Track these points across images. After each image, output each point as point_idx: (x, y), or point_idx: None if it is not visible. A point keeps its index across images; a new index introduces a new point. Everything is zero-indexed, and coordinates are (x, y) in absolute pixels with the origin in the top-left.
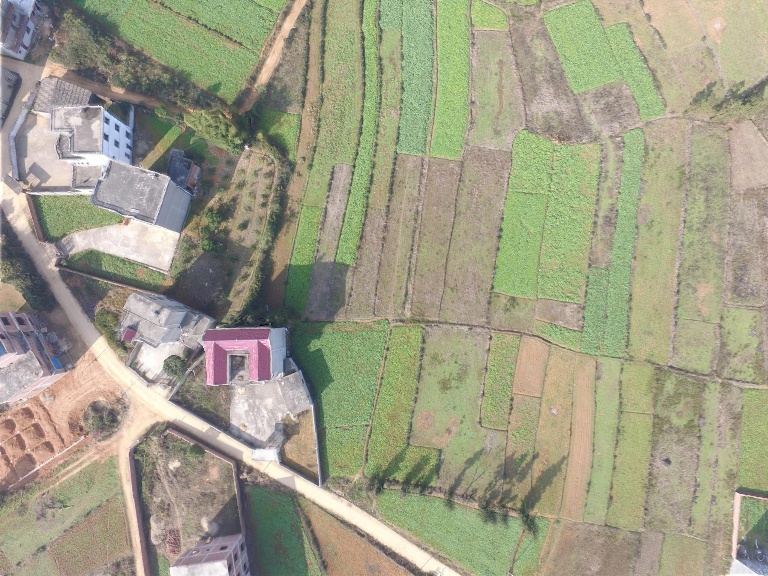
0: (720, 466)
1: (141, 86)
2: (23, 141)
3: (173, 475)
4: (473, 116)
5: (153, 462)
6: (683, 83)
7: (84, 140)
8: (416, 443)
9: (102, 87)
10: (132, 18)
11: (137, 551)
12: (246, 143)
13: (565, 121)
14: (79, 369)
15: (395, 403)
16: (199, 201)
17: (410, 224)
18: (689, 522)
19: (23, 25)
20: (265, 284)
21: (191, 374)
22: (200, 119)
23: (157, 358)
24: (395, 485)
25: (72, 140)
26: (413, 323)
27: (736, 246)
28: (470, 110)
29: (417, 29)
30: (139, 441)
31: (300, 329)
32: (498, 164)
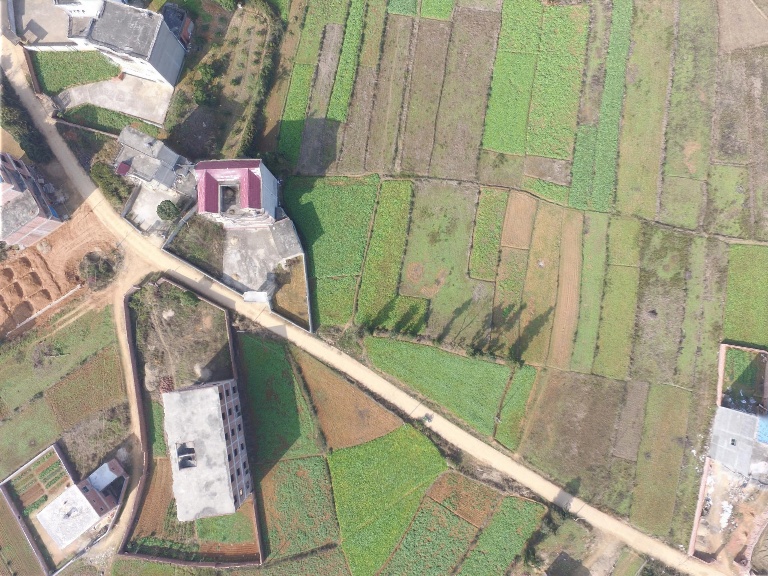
0: (706, 318)
1: None
2: None
3: (167, 324)
4: None
5: (147, 312)
6: None
7: None
8: (405, 293)
9: None
10: None
11: (132, 398)
12: (239, 1)
13: None
14: (75, 220)
15: (385, 254)
16: (193, 57)
17: (400, 82)
18: (674, 371)
19: None
20: (257, 139)
21: (185, 226)
22: None
23: (151, 210)
24: (384, 333)
25: None
26: (403, 178)
27: (723, 105)
28: None
29: None
30: (133, 286)
31: (292, 183)
32: (488, 24)
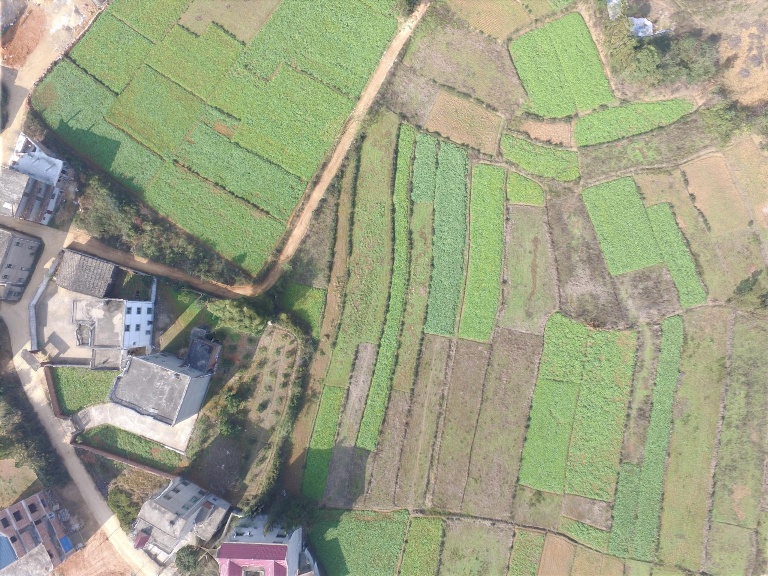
0: None
1: (165, 257)
2: (43, 309)
3: None
4: (504, 296)
5: None
6: (727, 270)
7: (105, 334)
8: None
9: (125, 256)
10: (158, 183)
11: None
12: (269, 319)
13: (601, 305)
14: (90, 548)
15: None
16: (219, 380)
17: (435, 409)
18: None
19: (48, 195)
20: (283, 468)
21: (203, 558)
22: (224, 311)
23: None
24: None
25: (93, 333)
26: (434, 515)
27: None
28: (502, 290)
29: (450, 203)
30: None
31: (317, 516)
32: (529, 349)
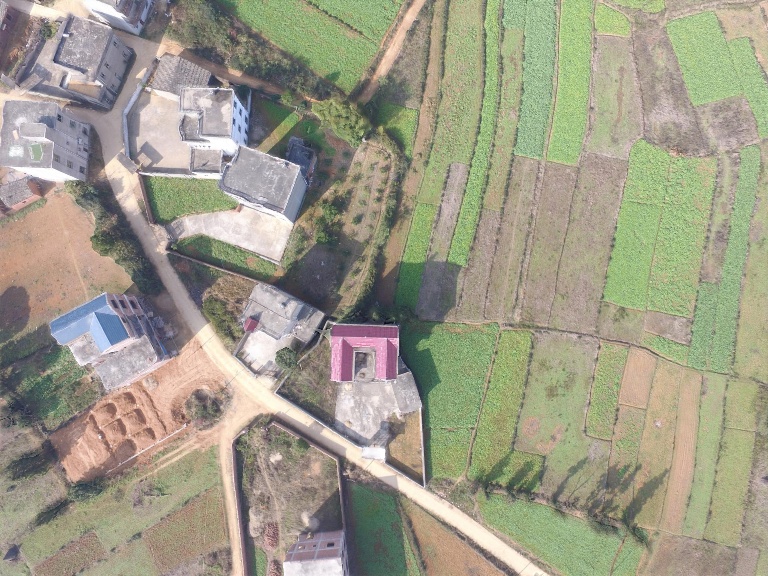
0: None
1: (260, 70)
2: (135, 119)
3: (274, 468)
4: (591, 122)
5: (254, 454)
6: None
7: (213, 123)
8: (520, 448)
9: (219, 68)
10: None
11: (234, 543)
12: (364, 135)
13: (683, 133)
14: (184, 356)
15: (501, 407)
16: (314, 192)
17: (524, 228)
18: None
19: None
20: (376, 280)
21: (297, 367)
22: (330, 109)
23: (264, 349)
24: (498, 489)
25: (201, 122)
26: (523, 328)
27: None
28: (589, 116)
29: (540, 30)
30: (245, 432)
31: (409, 328)
32: (614, 172)
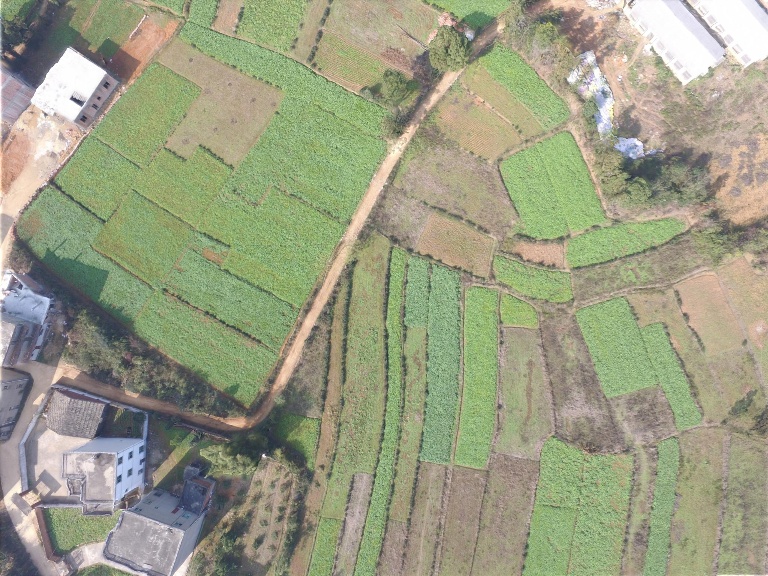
0: None
1: (156, 392)
2: (33, 446)
3: None
4: (500, 421)
5: None
6: (722, 390)
7: (96, 488)
8: None
9: (116, 390)
10: (148, 313)
11: None
12: None
13: (596, 428)
14: None
15: None
16: (213, 516)
17: (432, 539)
18: None
19: (36, 335)
20: None
21: None
22: (217, 458)
23: None
24: None
25: (84, 487)
26: None
27: None
28: (497, 415)
29: (443, 327)
30: None
31: None
32: (525, 475)
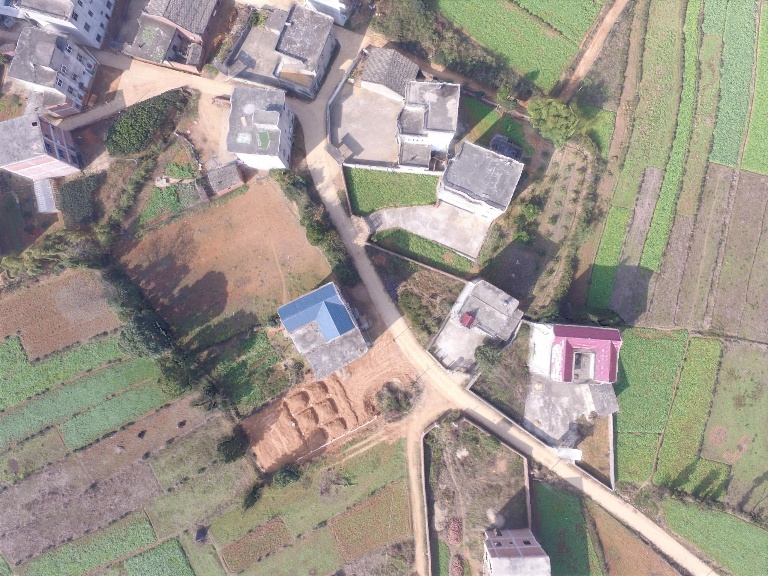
0: None
1: (463, 66)
2: (338, 110)
3: (461, 464)
4: None
5: (441, 449)
6: None
7: (438, 118)
8: (707, 456)
9: (421, 63)
10: None
11: (417, 535)
12: None
13: None
14: (376, 348)
15: (689, 414)
16: None
17: (716, 236)
18: None
19: None
20: None
21: None
22: (549, 108)
23: (456, 345)
24: (684, 496)
25: (426, 116)
26: (713, 336)
27: None
28: None
29: (739, 36)
30: None
31: None
32: None
